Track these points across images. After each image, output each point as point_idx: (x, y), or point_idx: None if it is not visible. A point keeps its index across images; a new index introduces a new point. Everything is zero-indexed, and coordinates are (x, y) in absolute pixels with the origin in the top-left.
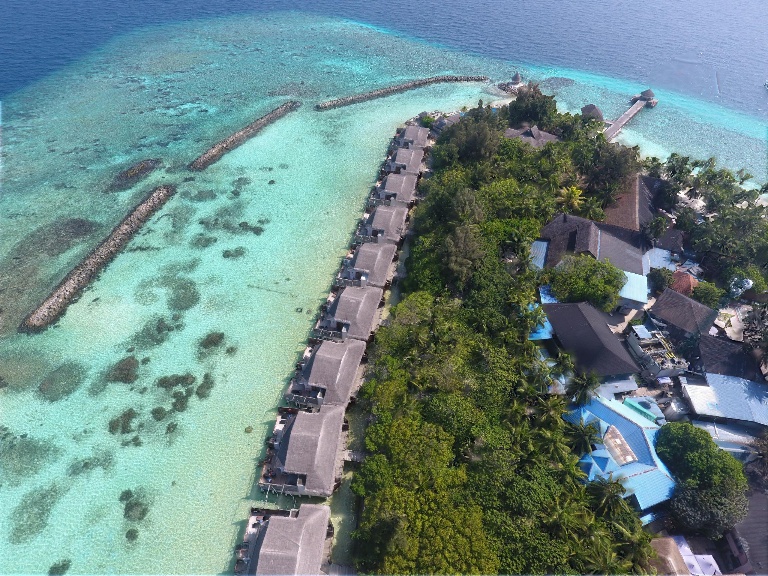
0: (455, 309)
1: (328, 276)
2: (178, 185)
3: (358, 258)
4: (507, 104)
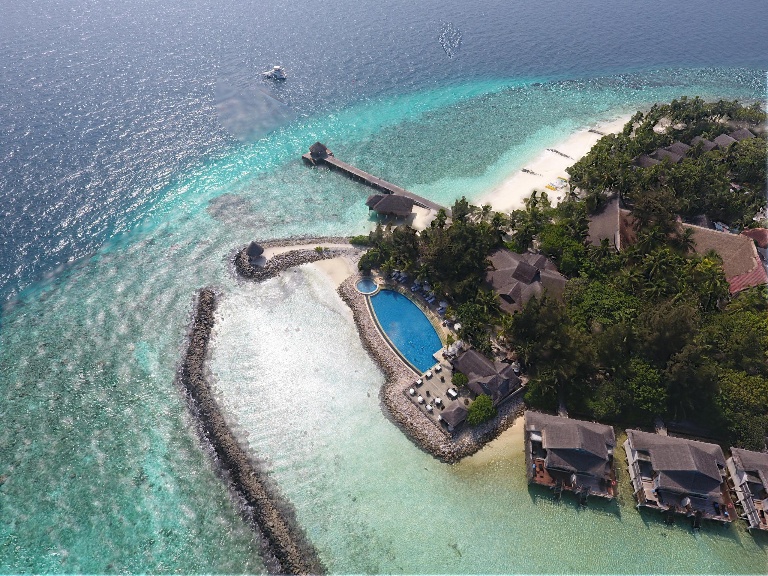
0: None
1: None
2: None
3: None
4: (355, 283)
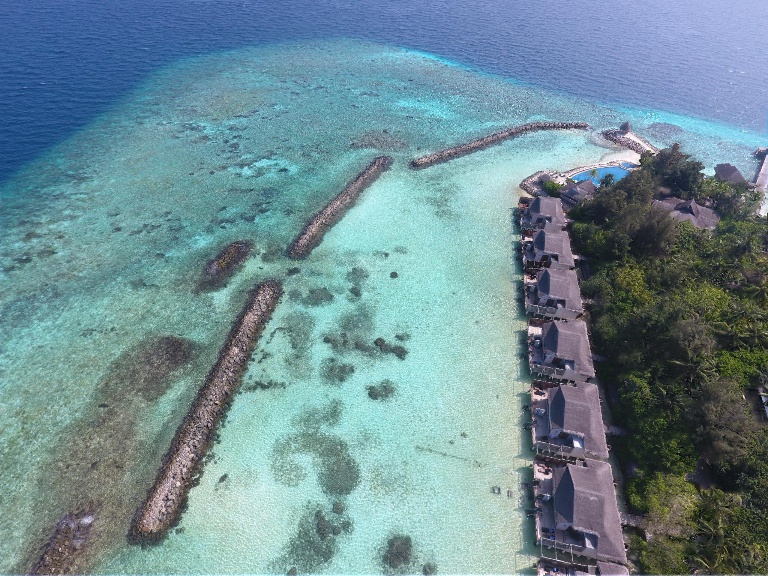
0: (736, 511)
1: (514, 429)
2: (282, 280)
3: (566, 415)
4: (627, 161)
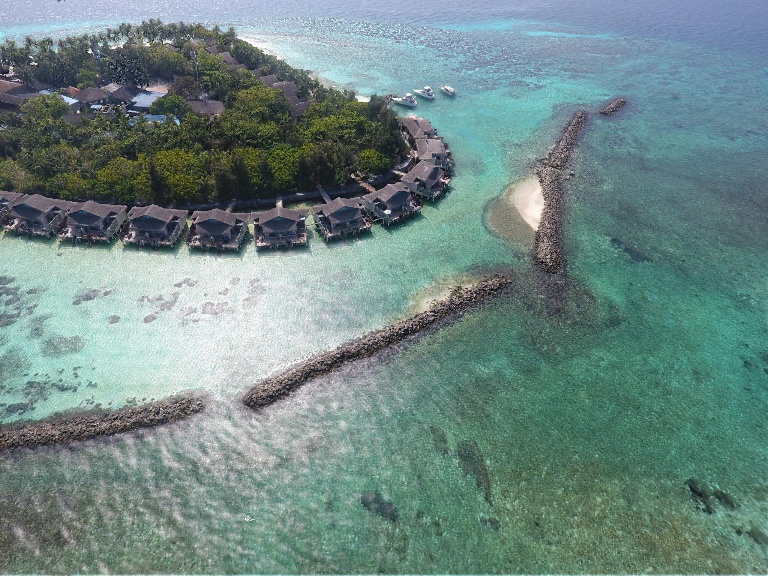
0: None
1: None
2: None
3: None
4: None
